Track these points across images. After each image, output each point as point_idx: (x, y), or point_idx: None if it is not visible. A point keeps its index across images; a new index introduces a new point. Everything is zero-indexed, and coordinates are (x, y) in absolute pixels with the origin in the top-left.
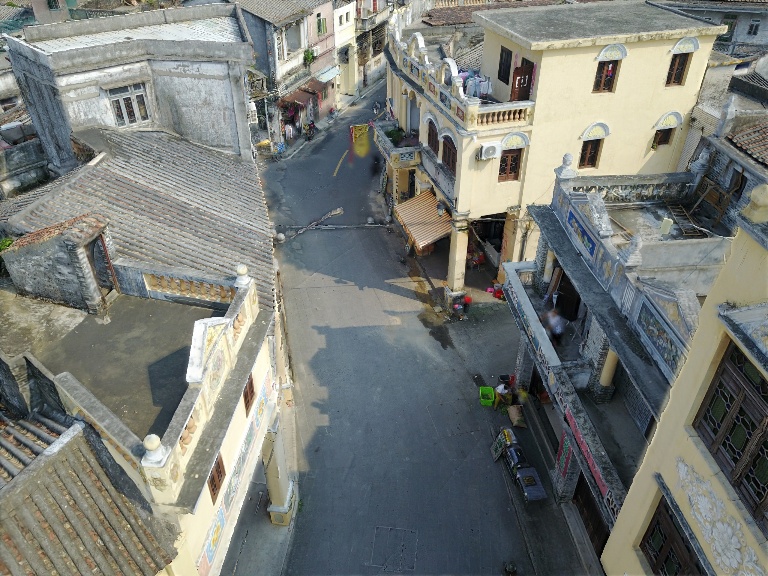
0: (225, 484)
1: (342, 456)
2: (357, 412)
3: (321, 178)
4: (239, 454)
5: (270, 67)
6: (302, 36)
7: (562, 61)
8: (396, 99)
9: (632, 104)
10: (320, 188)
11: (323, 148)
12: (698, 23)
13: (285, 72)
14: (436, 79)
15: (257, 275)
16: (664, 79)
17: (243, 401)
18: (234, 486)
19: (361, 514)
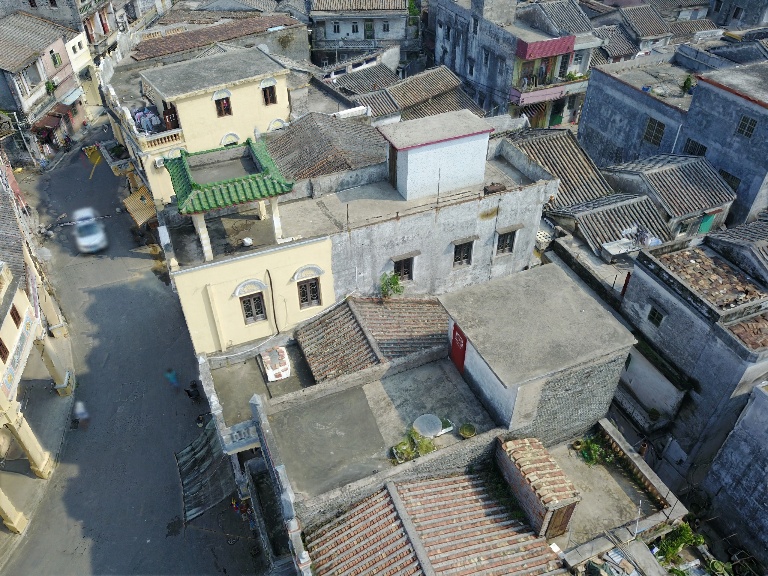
0: (10, 357)
1: (101, 356)
2: (110, 332)
3: (79, 183)
4: (17, 346)
5: (16, 103)
6: (40, 72)
7: (190, 104)
8: (112, 125)
9: (247, 119)
10: (79, 191)
11: (79, 157)
12: (276, 66)
13: (31, 104)
14: (123, 118)
15: (13, 261)
16: (262, 102)
17: (13, 321)
18: (17, 360)
19: (113, 380)
